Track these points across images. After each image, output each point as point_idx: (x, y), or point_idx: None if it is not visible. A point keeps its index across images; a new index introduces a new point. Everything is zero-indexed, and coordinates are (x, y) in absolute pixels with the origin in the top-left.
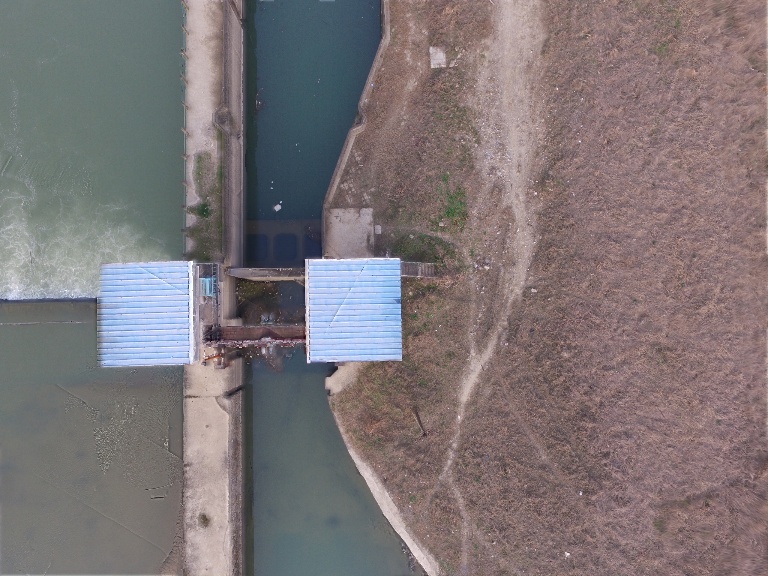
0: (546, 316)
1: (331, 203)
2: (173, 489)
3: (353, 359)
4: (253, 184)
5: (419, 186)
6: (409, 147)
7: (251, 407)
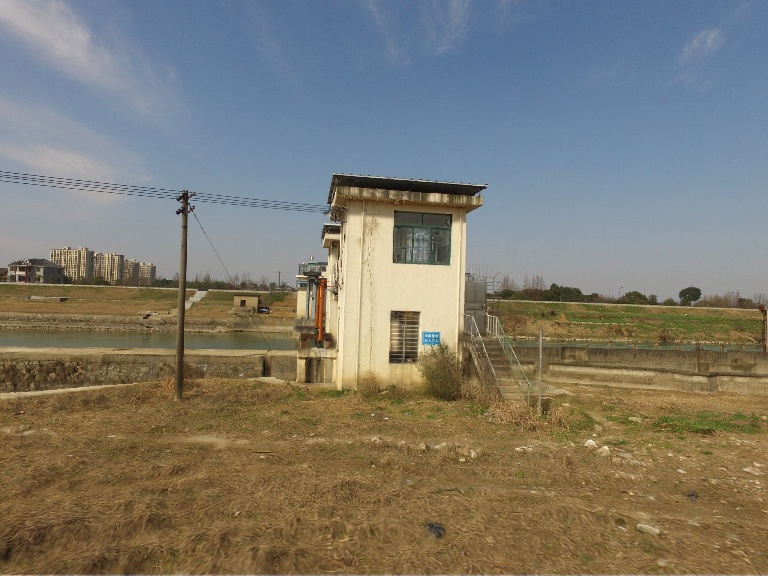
0: (553, 569)
1: (547, 381)
2: None
3: None
4: None
5: None
6: None
7: None
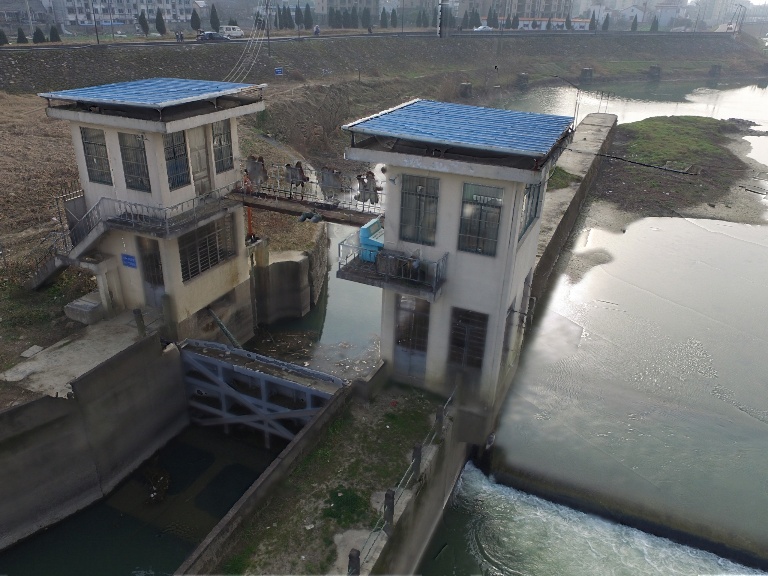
0: None
1: None
2: (582, 299)
3: None
4: None
5: None
6: None
7: None
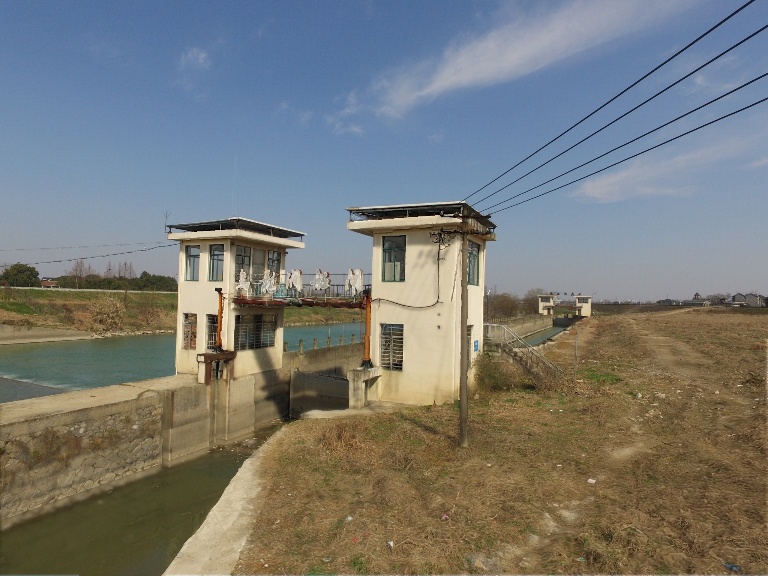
0: None
1: None
2: None
3: None
4: None
5: None
6: None
7: (112, 557)
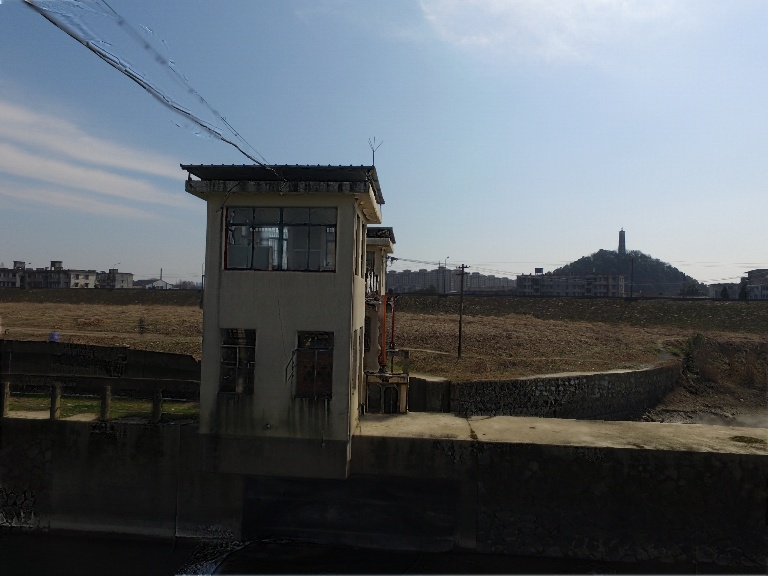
0: None
1: None
2: None
3: None
4: None
5: None
6: None
7: None
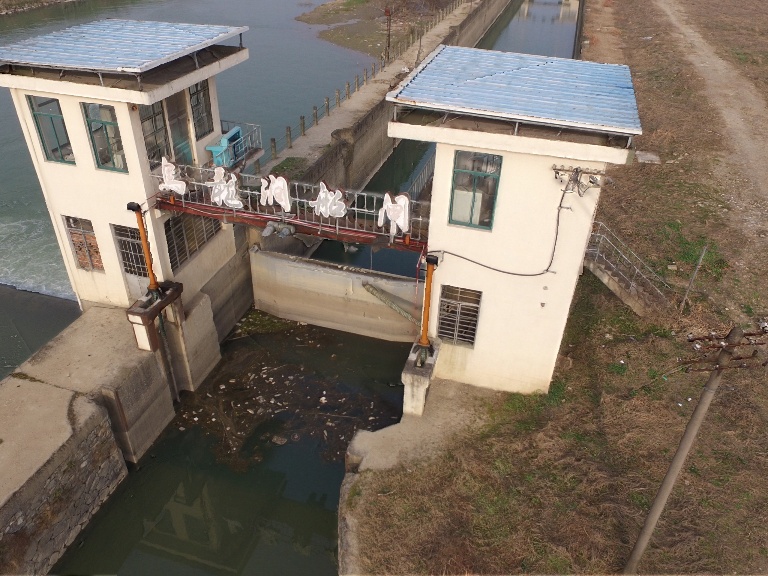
0: None
1: None
2: None
3: (506, 112)
4: (340, 244)
5: (625, 227)
6: (606, 203)
7: None
